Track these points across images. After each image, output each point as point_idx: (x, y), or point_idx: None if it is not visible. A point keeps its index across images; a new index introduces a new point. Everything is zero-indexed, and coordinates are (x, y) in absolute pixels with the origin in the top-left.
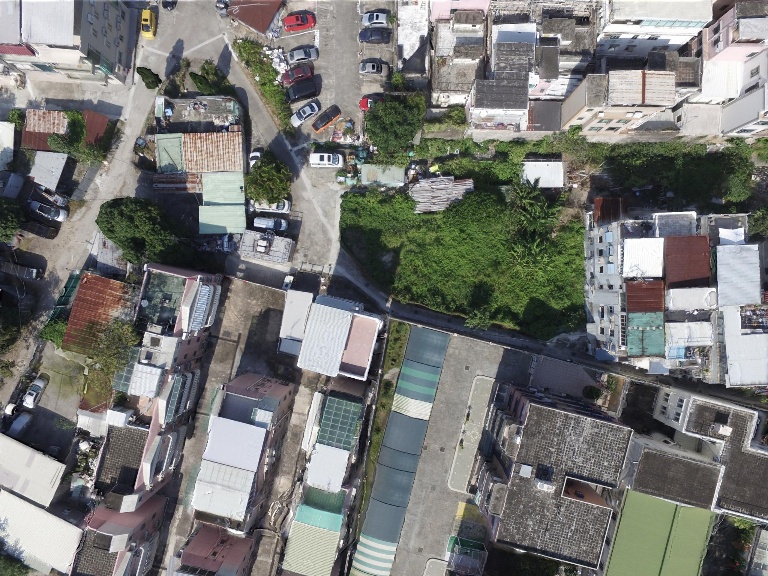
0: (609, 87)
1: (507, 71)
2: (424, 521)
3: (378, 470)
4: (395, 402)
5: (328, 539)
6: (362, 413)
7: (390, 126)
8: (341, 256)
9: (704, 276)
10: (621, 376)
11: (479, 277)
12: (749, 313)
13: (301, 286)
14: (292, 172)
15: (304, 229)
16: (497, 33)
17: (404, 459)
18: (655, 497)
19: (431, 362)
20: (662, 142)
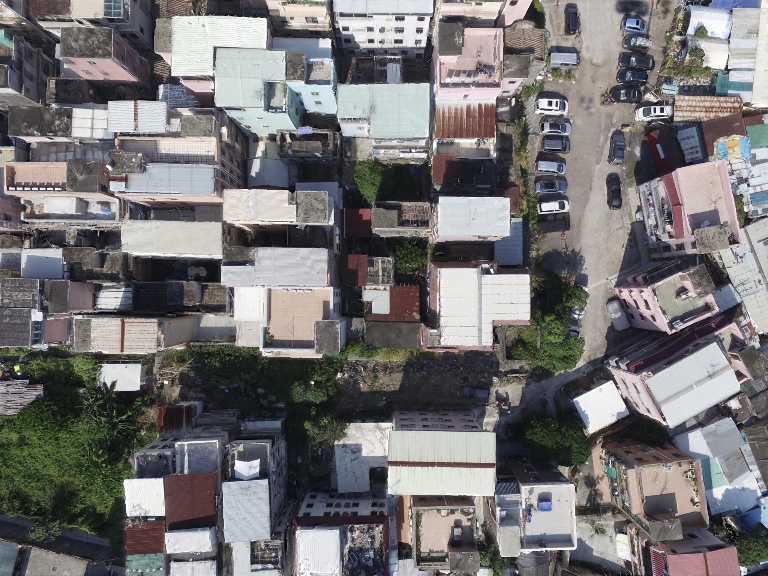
0: (91, 334)
1: (10, 308)
2: None
3: None
4: None
5: None
6: None
7: None
8: None
9: (210, 514)
10: None
11: (64, 477)
12: (263, 547)
13: None
14: None
15: None
16: (26, 257)
17: None
18: None
19: None
20: None
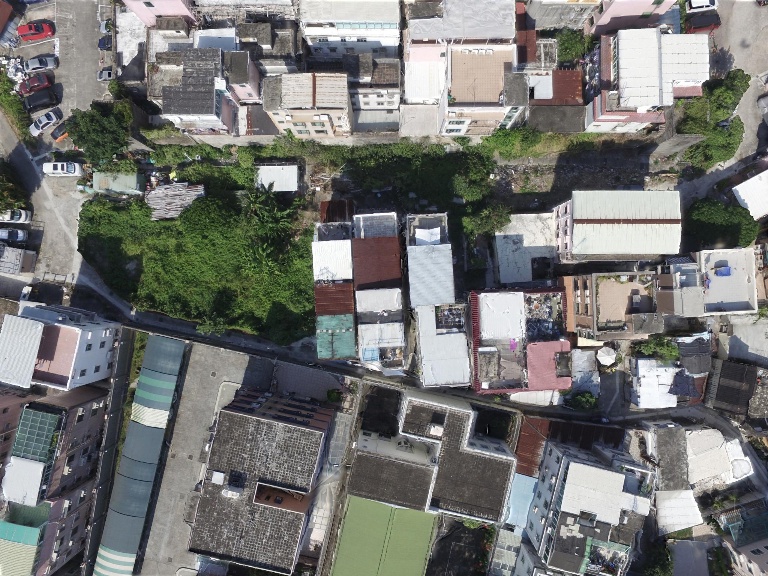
0: (282, 90)
1: (193, 76)
2: (173, 530)
3: (116, 480)
4: (133, 411)
5: (24, 553)
6: (59, 424)
7: (87, 134)
8: (84, 265)
9: (395, 277)
10: (355, 378)
11: (222, 283)
12: (446, 313)
13: (44, 296)
14: (33, 182)
15: (46, 239)
16: (198, 38)
17: (140, 468)
18: (369, 500)
19: (165, 370)
20: (396, 143)
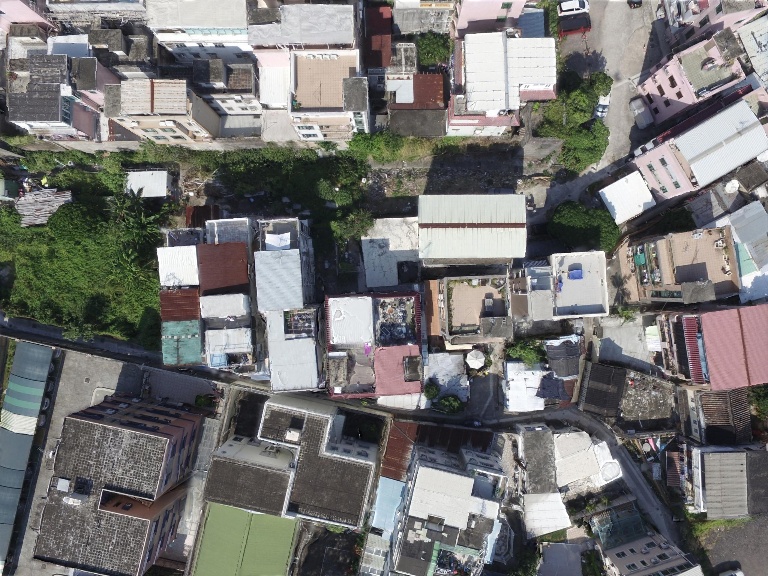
0: (121, 97)
1: (39, 83)
2: None
3: None
4: (2, 418)
5: None
6: None
7: None
8: None
9: (243, 282)
10: (222, 384)
11: (94, 288)
12: (296, 318)
13: None
14: None
15: None
16: (52, 45)
17: (8, 475)
18: (226, 505)
19: (33, 376)
20: (265, 148)
